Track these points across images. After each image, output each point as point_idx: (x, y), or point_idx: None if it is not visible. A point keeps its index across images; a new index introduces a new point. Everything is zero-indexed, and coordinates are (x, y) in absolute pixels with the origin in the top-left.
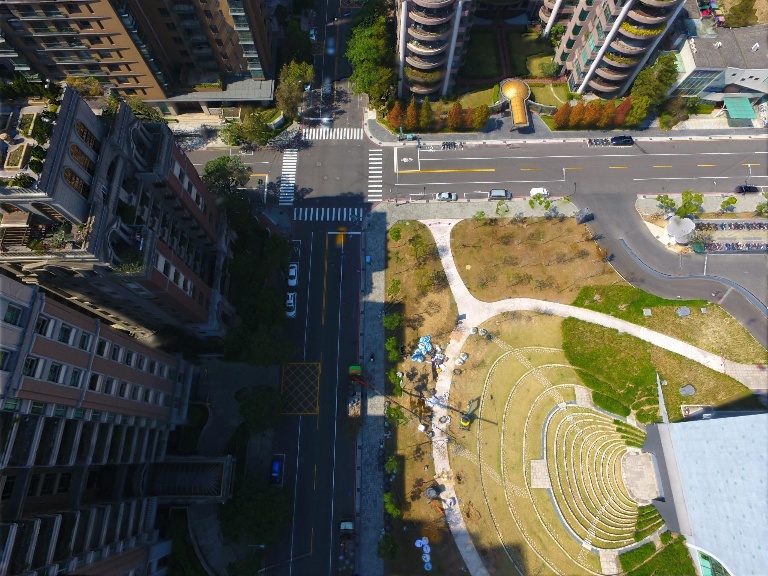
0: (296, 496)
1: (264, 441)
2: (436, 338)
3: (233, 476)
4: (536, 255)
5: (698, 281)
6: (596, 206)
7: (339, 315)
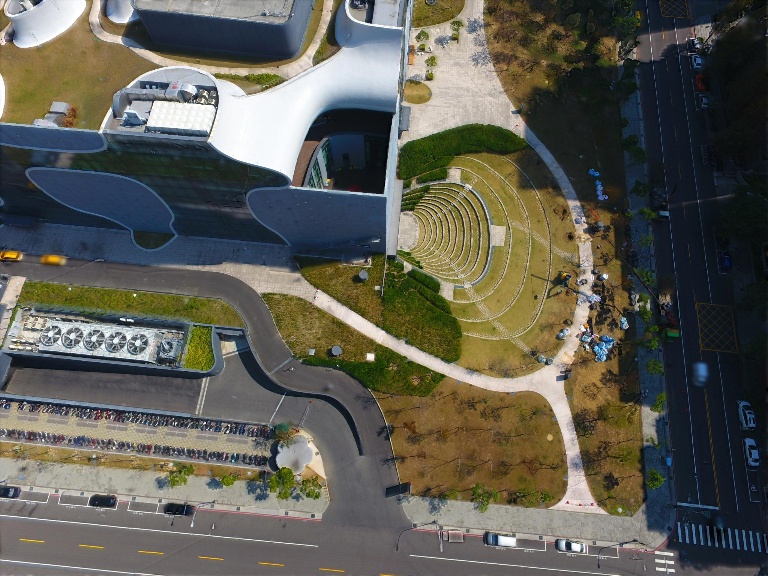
0: (703, 241)
1: (741, 285)
2: (589, 359)
3: (764, 259)
4: (471, 443)
5: (301, 387)
6: (379, 508)
7: (689, 398)
